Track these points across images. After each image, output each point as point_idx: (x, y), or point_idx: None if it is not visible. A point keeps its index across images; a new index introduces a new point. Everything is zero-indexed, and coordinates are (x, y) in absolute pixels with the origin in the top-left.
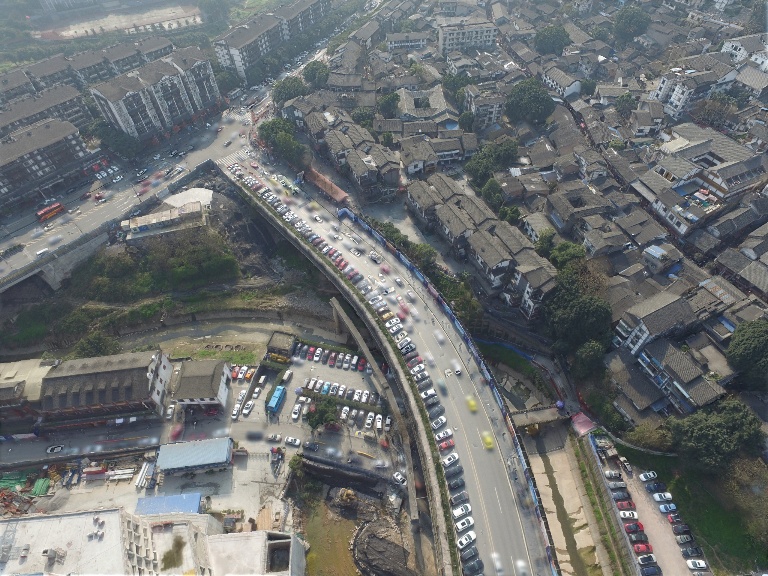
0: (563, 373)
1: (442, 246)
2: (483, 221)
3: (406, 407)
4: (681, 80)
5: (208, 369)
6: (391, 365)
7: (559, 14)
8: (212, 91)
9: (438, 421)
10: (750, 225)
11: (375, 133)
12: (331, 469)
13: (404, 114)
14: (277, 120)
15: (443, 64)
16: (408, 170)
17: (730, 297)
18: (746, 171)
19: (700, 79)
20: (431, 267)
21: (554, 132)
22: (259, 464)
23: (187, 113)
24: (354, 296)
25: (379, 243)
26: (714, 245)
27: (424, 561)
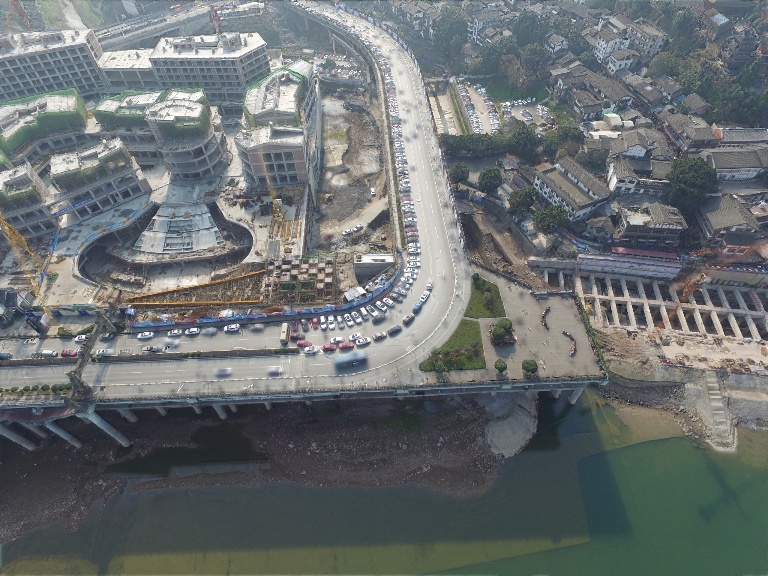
0: (448, 66)
1: (392, 20)
2: (412, 1)
3: (367, 57)
4: None
5: None
6: (361, 47)
7: None
8: None
9: (381, 58)
10: None
11: None
12: (333, 82)
13: None
14: None
15: None
16: None
17: None
18: None
19: None
20: None
21: None
22: None
23: None
24: None
25: (358, 17)
26: None
27: (373, 103)
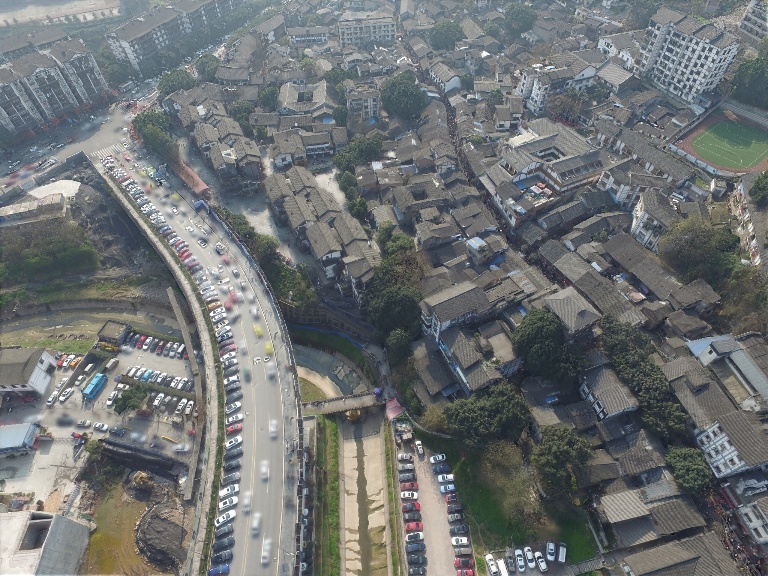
0: (388, 361)
1: (292, 238)
2: (324, 213)
3: None
4: (537, 76)
5: (24, 357)
6: (202, 353)
7: (459, 10)
8: (98, 84)
9: (231, 406)
10: (582, 218)
11: (250, 126)
12: (129, 453)
13: (283, 108)
14: (151, 113)
15: (338, 58)
16: (276, 163)
17: (532, 287)
18: (582, 165)
19: (554, 75)
20: (274, 258)
21: (422, 126)
22: (62, 449)
23: (71, 105)
24: (188, 286)
25: (227, 234)
26: (541, 237)
27: None
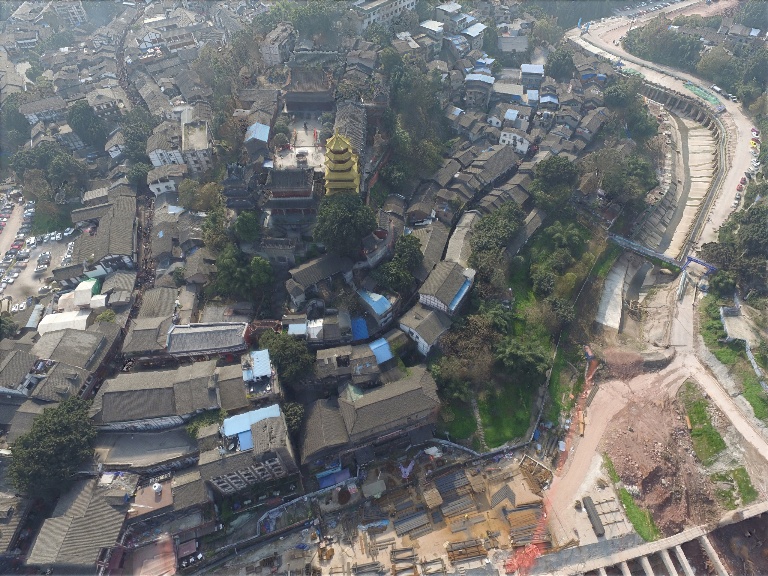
0: None
1: None
2: None
3: None
4: None
5: None
6: None
7: None
8: None
9: None
10: None
11: None
12: None
13: (12, 18)
14: None
15: None
16: None
17: None
18: (186, 33)
19: None
20: None
21: (108, 24)
22: None
23: None
24: None
25: None
26: None
27: None
